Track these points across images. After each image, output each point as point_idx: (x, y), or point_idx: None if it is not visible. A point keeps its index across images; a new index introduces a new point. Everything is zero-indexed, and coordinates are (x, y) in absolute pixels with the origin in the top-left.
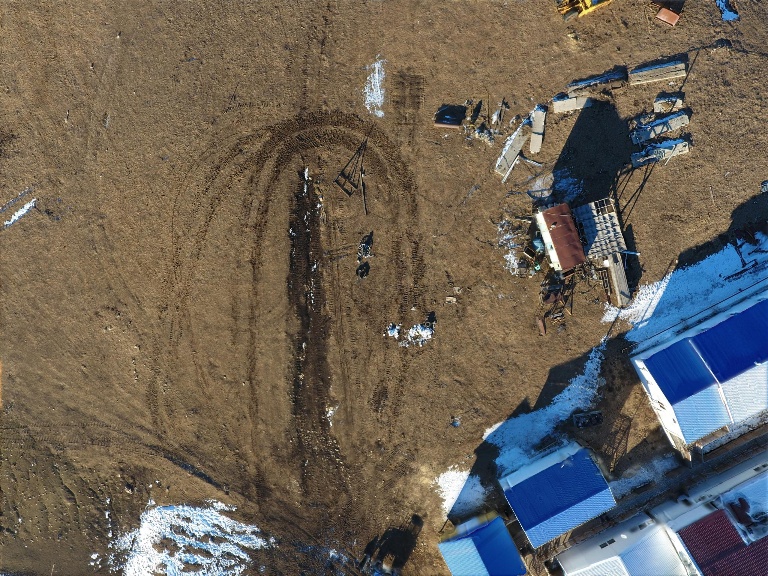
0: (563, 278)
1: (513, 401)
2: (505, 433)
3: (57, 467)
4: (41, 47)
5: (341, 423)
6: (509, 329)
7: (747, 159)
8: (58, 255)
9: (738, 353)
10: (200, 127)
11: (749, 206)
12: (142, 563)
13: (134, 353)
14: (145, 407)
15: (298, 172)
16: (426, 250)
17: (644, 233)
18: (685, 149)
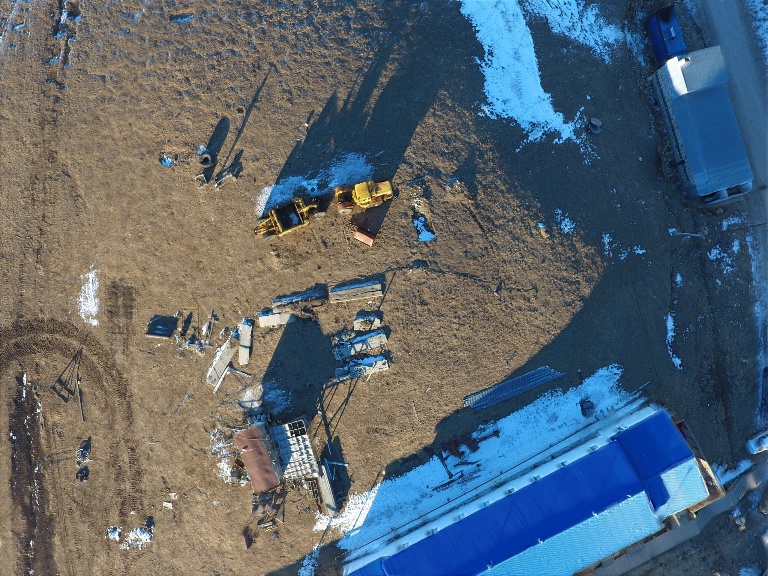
0: (269, 491)
1: None
2: None
3: None
4: None
5: None
6: (224, 536)
7: (448, 375)
8: None
9: None
10: None
11: (453, 420)
12: None
13: None
14: None
15: (16, 378)
16: (143, 456)
17: (351, 445)
18: (385, 366)
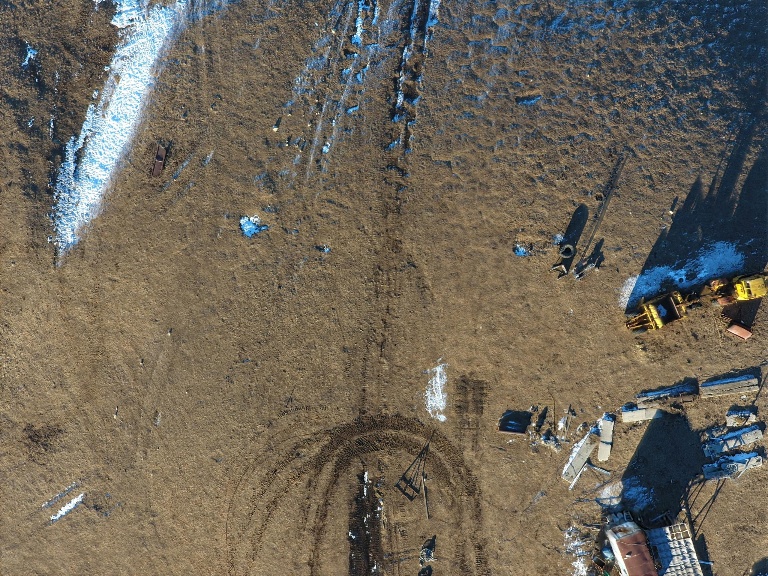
0: None
1: None
2: None
3: None
4: (89, 343)
5: None
6: None
7: None
8: (107, 551)
9: None
10: (256, 430)
11: None
12: None
13: None
14: None
15: (357, 476)
16: (491, 555)
17: (717, 543)
18: (759, 463)
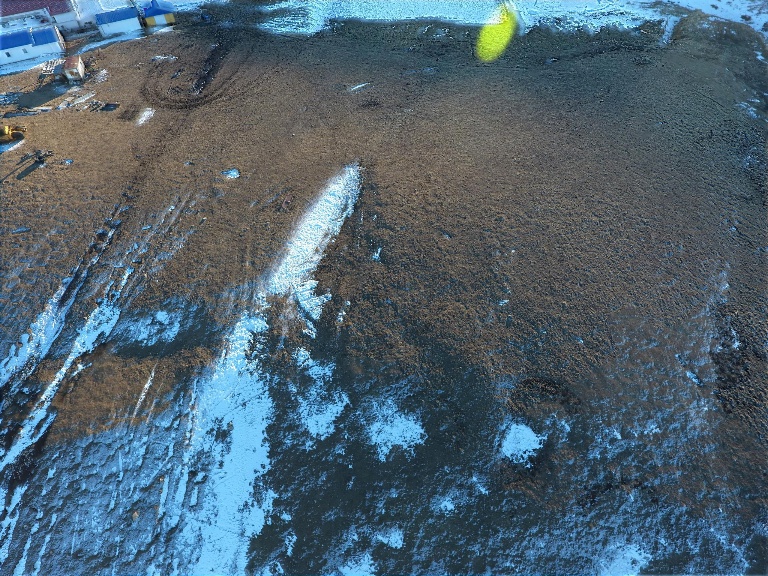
0: None
1: (127, 42)
2: (136, 37)
3: None
4: None
5: (212, 42)
6: None
7: None
8: None
9: (16, 37)
10: None
11: None
12: (321, 23)
13: None
14: None
15: None
16: None
17: None
18: None
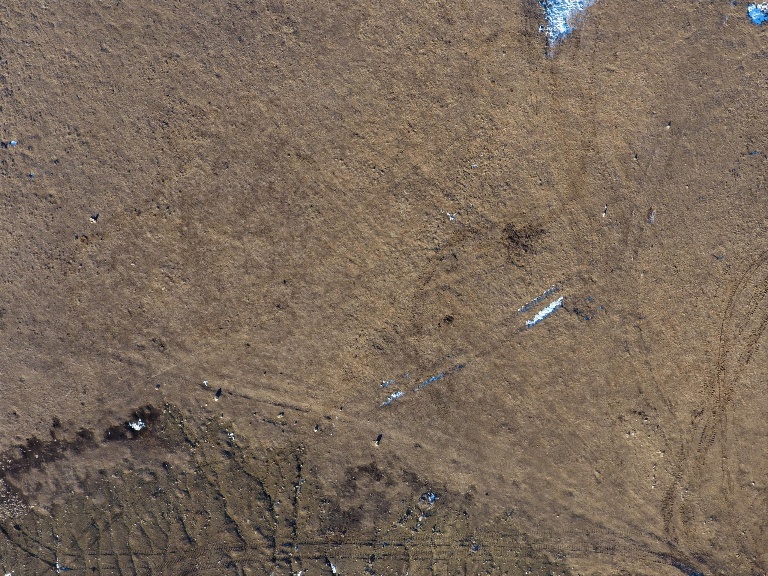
0: None
1: None
2: None
3: (553, 575)
4: (580, 137)
5: None
6: None
7: None
8: (585, 357)
9: None
10: (762, 225)
11: None
12: None
13: (656, 458)
14: (658, 513)
15: None
16: None
17: None
18: None
